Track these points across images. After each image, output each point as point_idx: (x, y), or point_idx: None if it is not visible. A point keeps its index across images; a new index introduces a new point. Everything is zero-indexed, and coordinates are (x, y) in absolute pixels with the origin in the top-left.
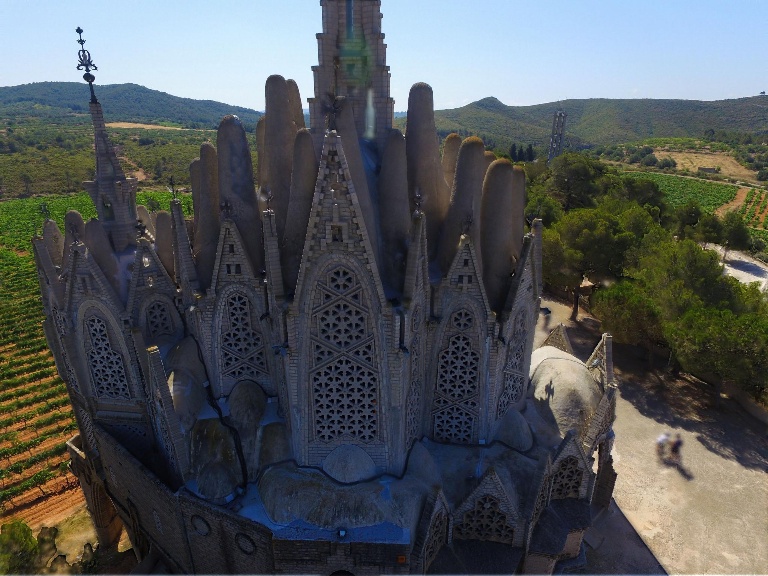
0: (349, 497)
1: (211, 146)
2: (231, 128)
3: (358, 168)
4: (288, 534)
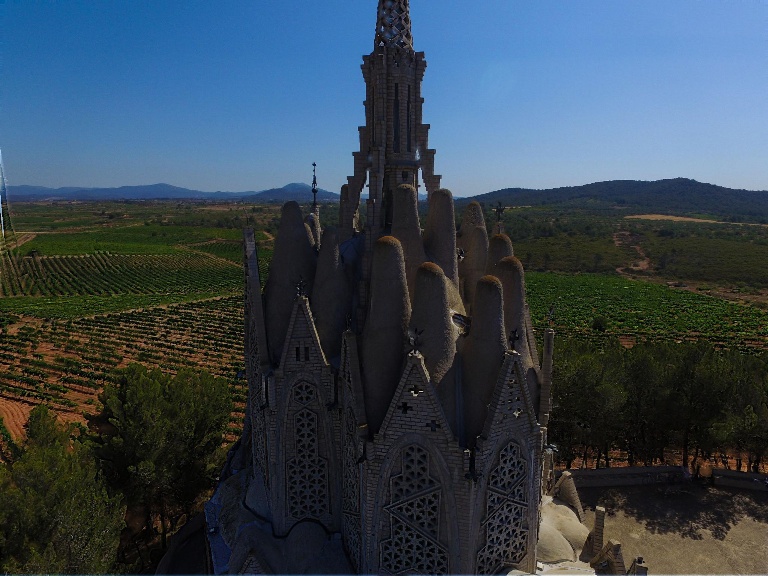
0: (234, 512)
1: (321, 233)
2: (306, 222)
3: (283, 254)
4: (209, 508)
